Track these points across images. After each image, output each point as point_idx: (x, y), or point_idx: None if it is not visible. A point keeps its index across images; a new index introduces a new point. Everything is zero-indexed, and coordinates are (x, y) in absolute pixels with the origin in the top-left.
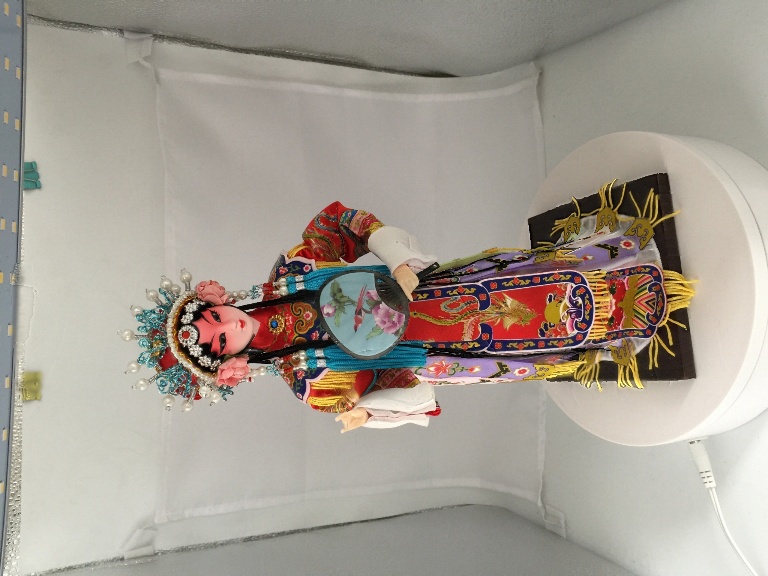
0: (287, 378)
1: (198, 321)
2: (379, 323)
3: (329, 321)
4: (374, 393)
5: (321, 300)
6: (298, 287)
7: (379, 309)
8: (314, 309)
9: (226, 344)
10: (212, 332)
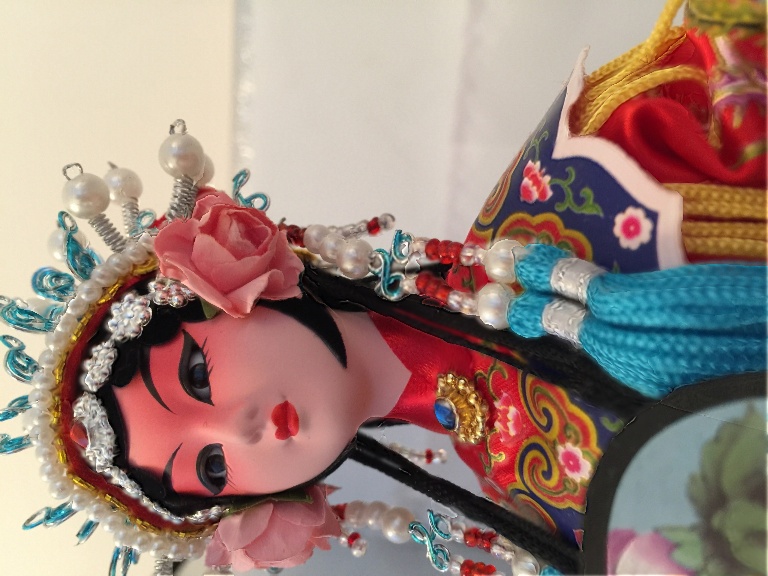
0: None
1: (127, 388)
2: None
3: None
4: None
5: (624, 493)
6: (552, 325)
7: None
8: None
9: (229, 476)
10: (168, 440)
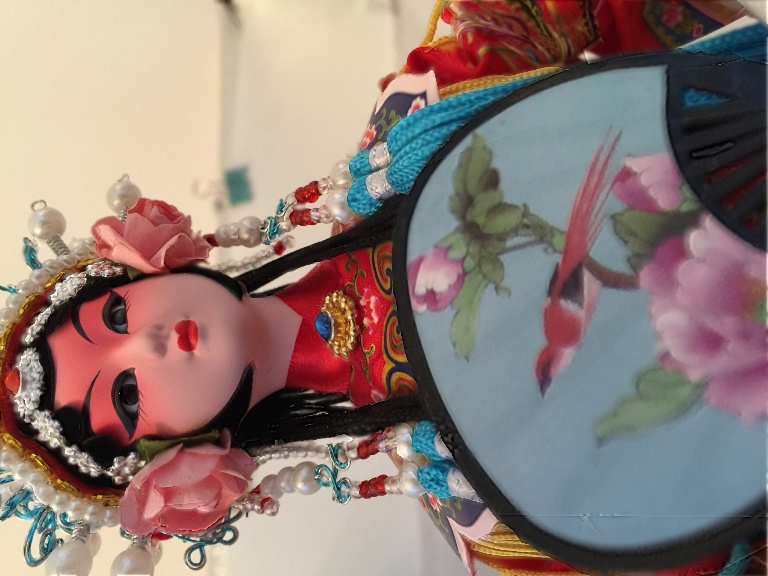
0: None
1: (59, 333)
2: (681, 346)
3: (429, 331)
4: None
5: (412, 233)
6: (374, 187)
7: (685, 260)
8: None
9: (140, 405)
10: (88, 369)
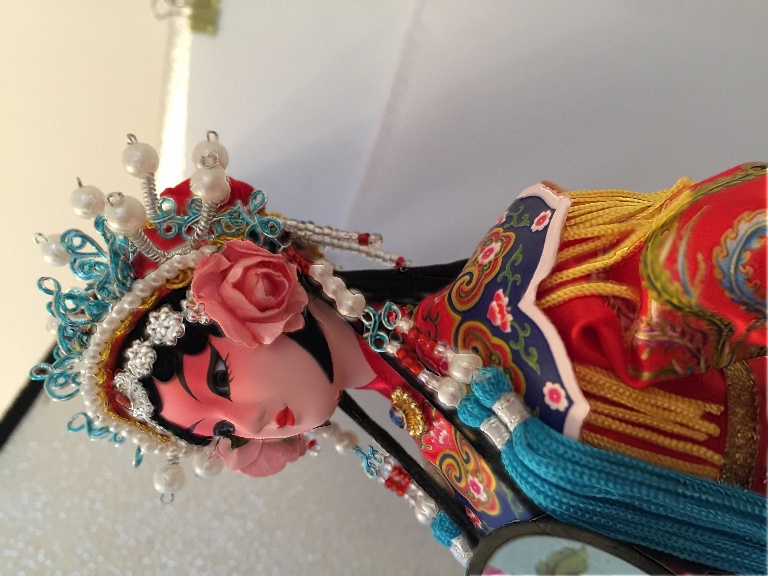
0: None
1: None
2: None
3: None
4: None
5: (501, 552)
6: (486, 430)
7: None
8: (497, 498)
9: (235, 433)
10: (194, 416)
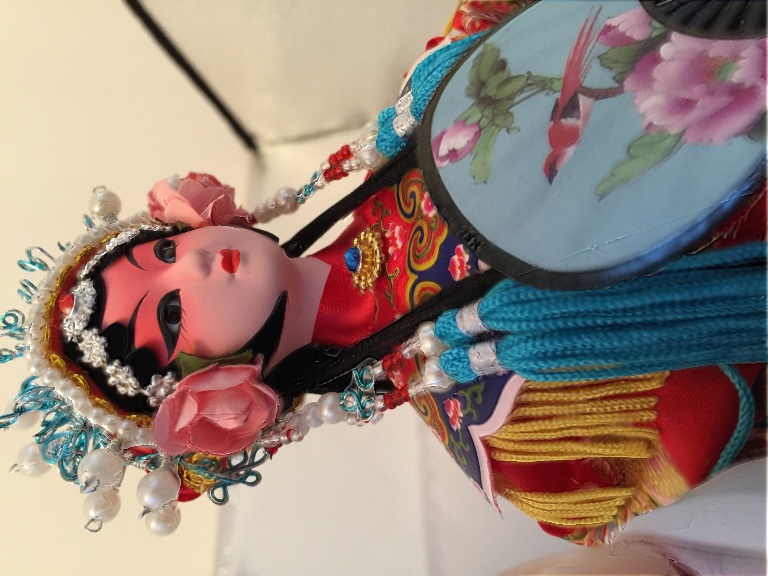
0: (433, 429)
1: (112, 266)
2: (660, 115)
3: (452, 175)
4: (736, 472)
5: (435, 120)
6: (399, 126)
7: (658, 64)
8: None
9: (182, 323)
10: (138, 290)
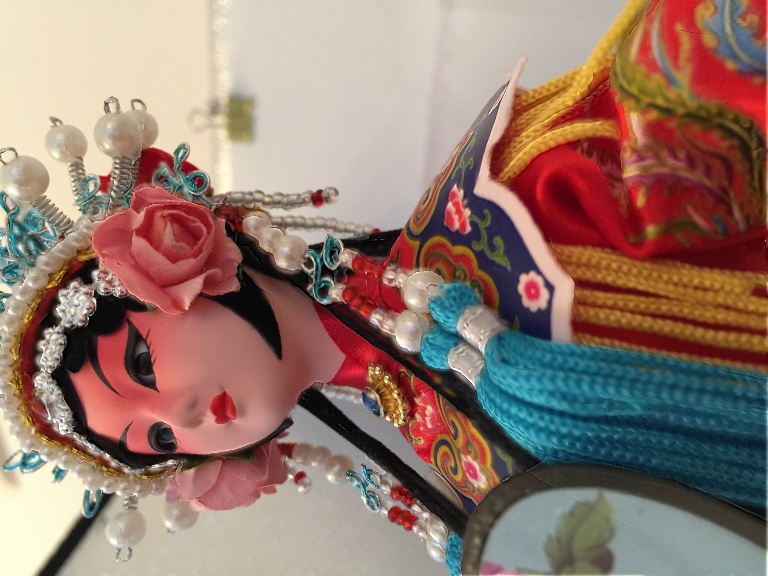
0: None
1: (79, 372)
2: None
3: None
4: None
5: (495, 536)
6: (456, 366)
7: None
8: (496, 476)
9: (178, 445)
10: (120, 418)
